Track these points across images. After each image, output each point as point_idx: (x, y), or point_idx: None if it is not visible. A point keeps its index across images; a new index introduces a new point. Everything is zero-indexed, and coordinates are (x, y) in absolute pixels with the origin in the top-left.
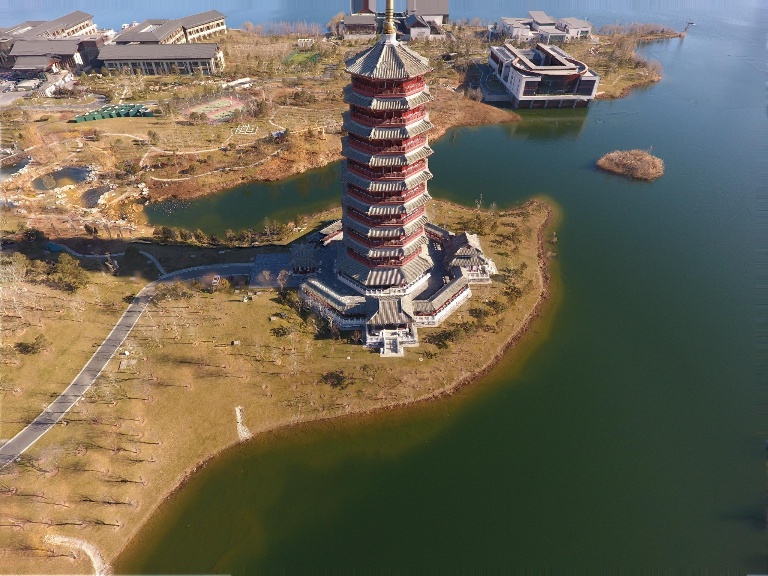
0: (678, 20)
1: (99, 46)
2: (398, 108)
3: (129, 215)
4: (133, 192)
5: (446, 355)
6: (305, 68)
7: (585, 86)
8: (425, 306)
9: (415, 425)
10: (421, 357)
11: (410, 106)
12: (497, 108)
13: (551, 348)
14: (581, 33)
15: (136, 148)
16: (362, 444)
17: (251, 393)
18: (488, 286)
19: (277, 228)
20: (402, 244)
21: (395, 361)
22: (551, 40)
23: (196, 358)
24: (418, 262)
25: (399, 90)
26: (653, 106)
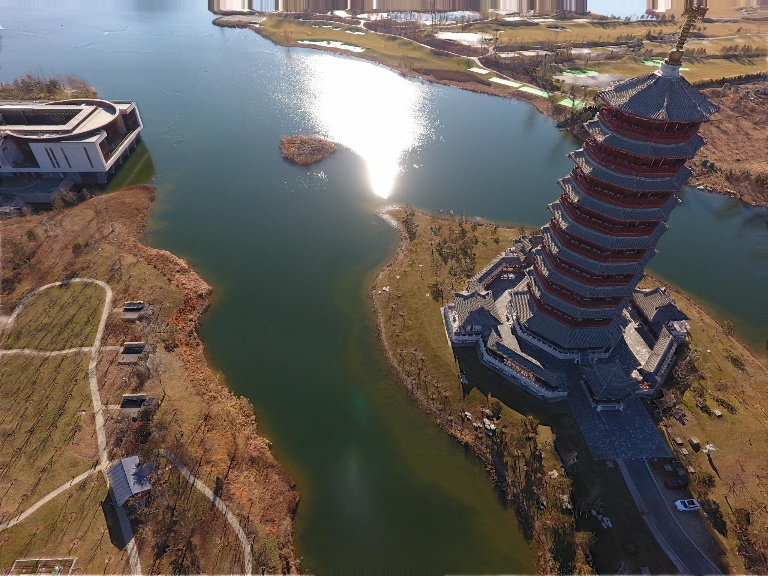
0: None
1: None
2: None
3: None
4: None
5: None
6: None
7: (131, 119)
8: None
9: None
10: None
11: None
12: (100, 196)
13: None
14: None
15: None
16: None
17: None
18: None
19: None
20: None
21: None
22: None
23: None
24: None
25: None
26: (161, 110)
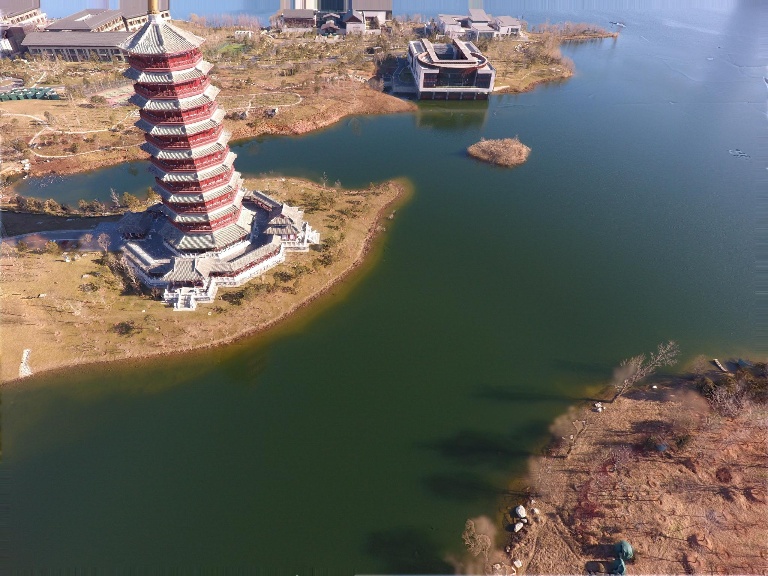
0: (610, 20)
1: (27, 33)
2: (164, 81)
3: (3, 187)
4: (15, 167)
5: (236, 311)
6: (229, 58)
7: (482, 79)
8: (224, 267)
9: (185, 369)
10: (210, 312)
11: (175, 80)
12: (400, 99)
13: (342, 308)
14: (511, 31)
15: (31, 128)
16: (130, 383)
17: (42, 338)
18: (303, 254)
19: (128, 200)
20: (206, 210)
21: (184, 314)
22: (480, 37)
23: (0, 308)
24: (234, 230)
25: (164, 65)
26: (552, 100)
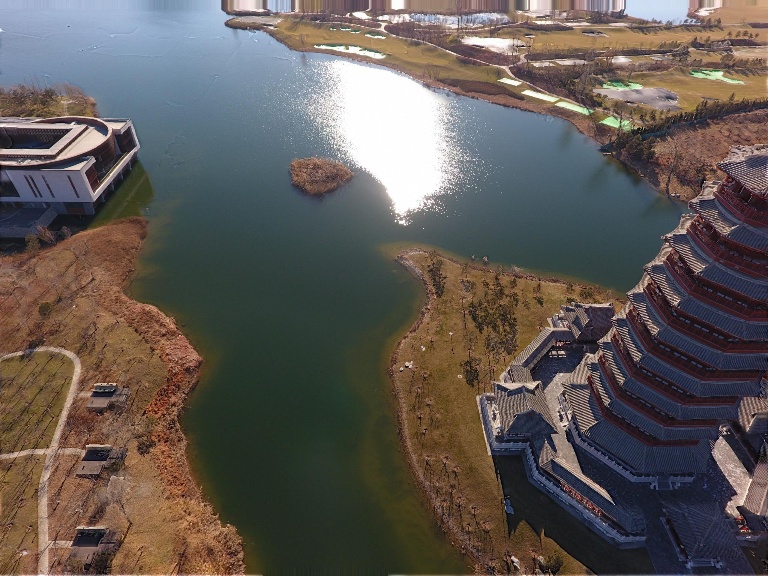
0: None
1: None
2: None
3: None
4: None
5: None
6: None
7: (126, 139)
8: None
9: None
10: None
11: None
12: (85, 231)
13: None
14: None
15: None
16: None
17: None
18: None
19: None
20: None
21: None
22: None
23: None
24: None
25: None
26: (163, 125)
